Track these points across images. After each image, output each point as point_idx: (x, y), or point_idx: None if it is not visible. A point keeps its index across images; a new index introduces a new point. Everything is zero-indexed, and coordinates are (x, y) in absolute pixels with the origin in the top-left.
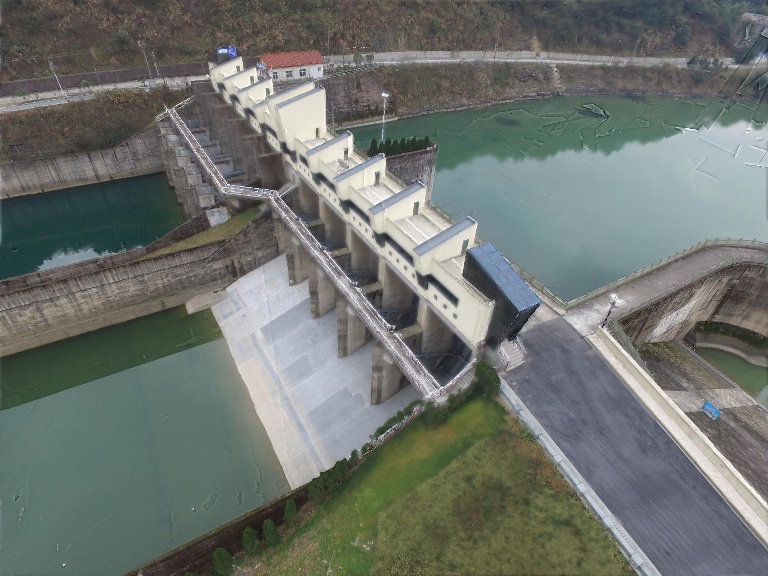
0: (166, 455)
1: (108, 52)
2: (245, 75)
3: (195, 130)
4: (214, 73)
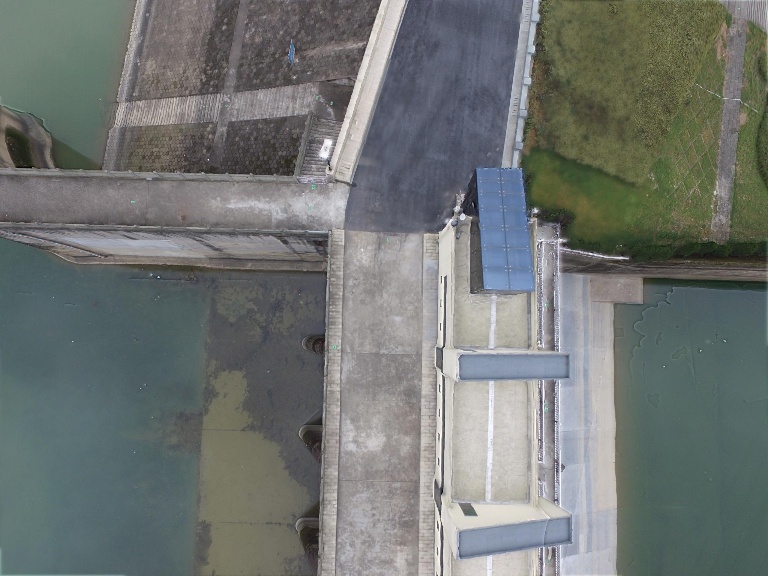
0: (705, 431)
1: None
2: None
3: None
4: None
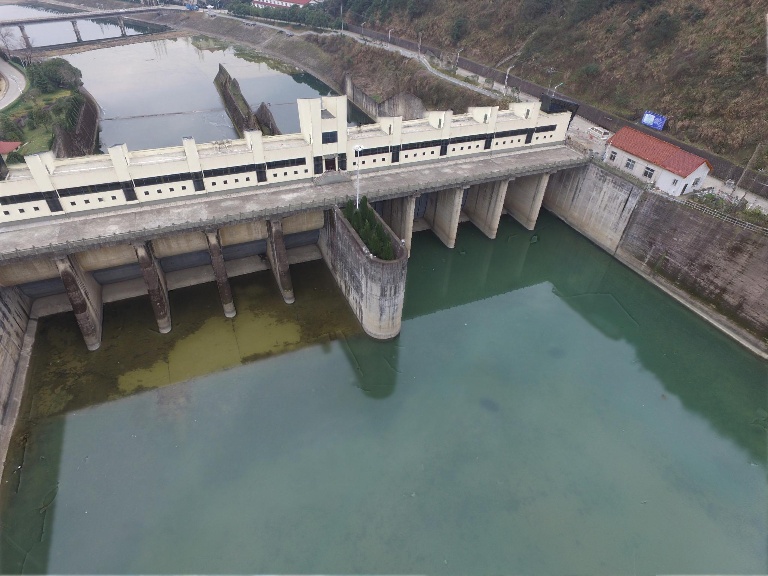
0: None
1: (579, 79)
2: (483, 110)
3: None
4: (511, 107)
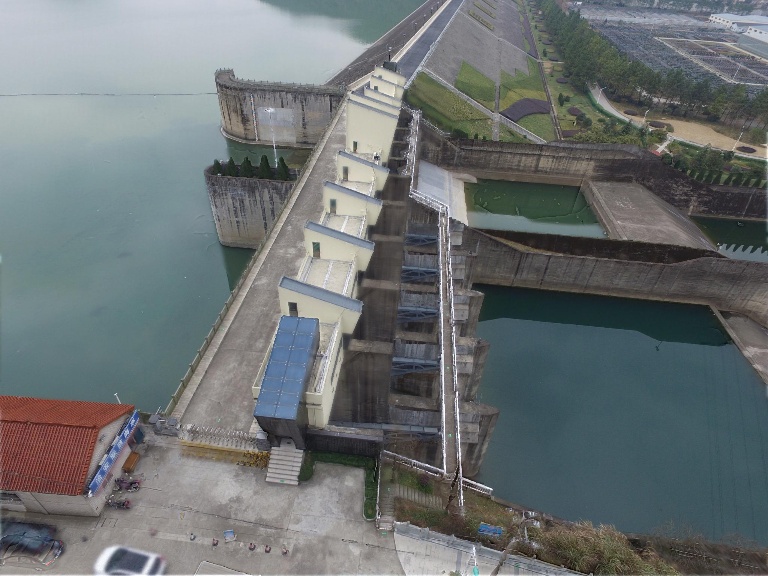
0: None
1: None
2: None
3: (418, 400)
4: None
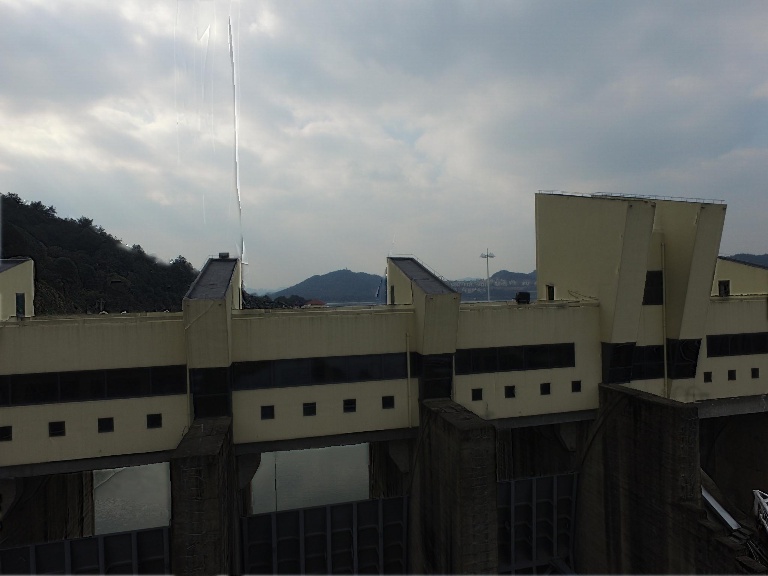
0: None
1: None
2: (2, 285)
3: None
4: None
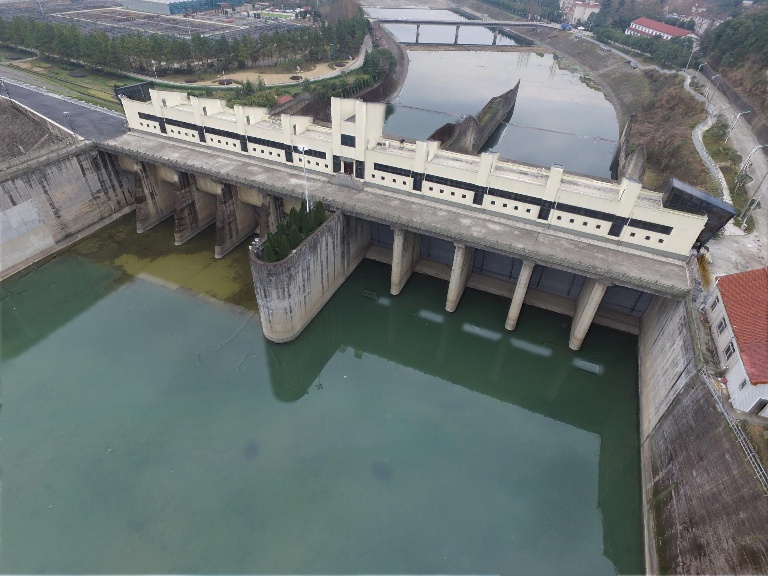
0: None
1: None
2: None
3: None
4: None
